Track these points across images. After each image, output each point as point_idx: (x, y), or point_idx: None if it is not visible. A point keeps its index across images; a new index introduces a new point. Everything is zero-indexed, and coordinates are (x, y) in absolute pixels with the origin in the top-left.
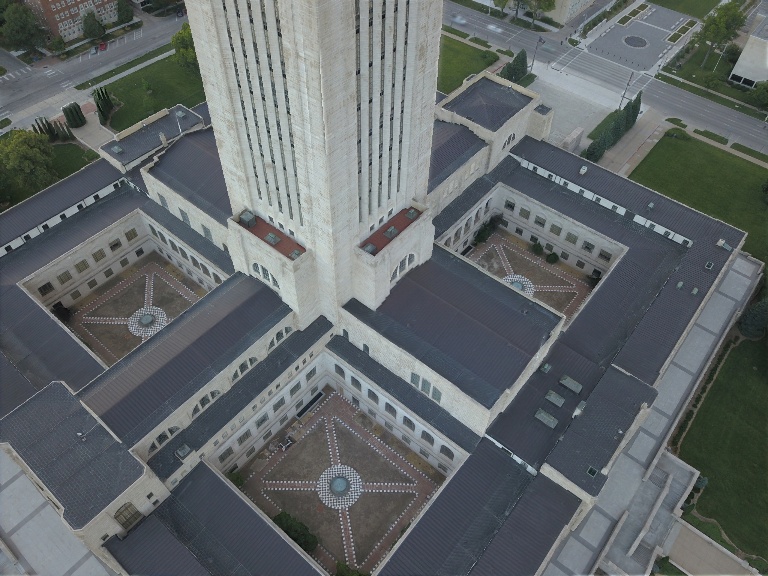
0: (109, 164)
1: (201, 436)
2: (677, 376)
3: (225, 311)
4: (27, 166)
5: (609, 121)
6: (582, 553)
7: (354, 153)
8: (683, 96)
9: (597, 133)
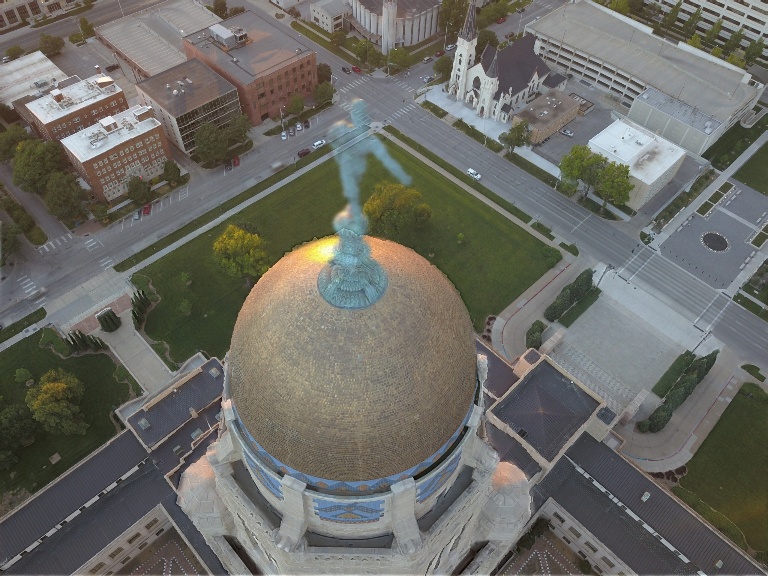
0: (135, 438)
1: None
2: None
3: None
4: (53, 421)
5: (678, 369)
6: None
7: None
8: (764, 331)
9: (663, 387)
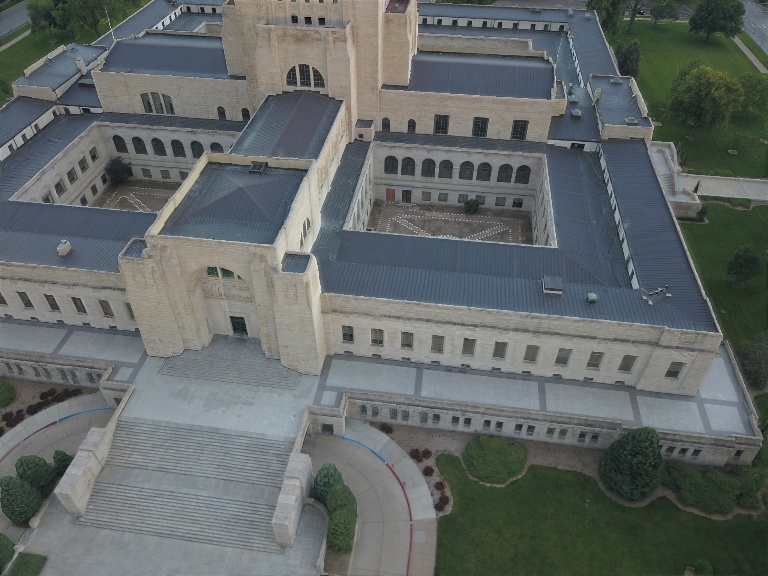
0: None
1: None
2: None
3: None
4: None
5: None
6: None
7: None
8: None
9: None
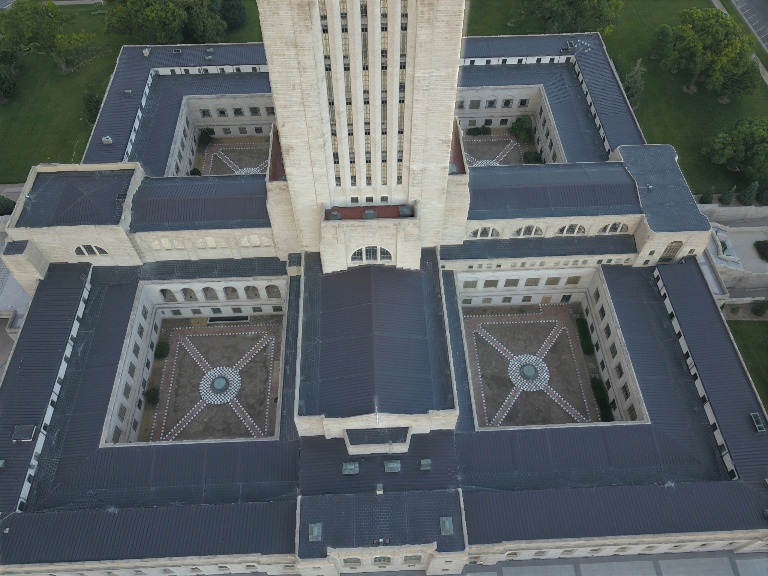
0: None
1: None
2: None
3: (505, 191)
4: None
5: None
6: None
7: None
8: None
9: None
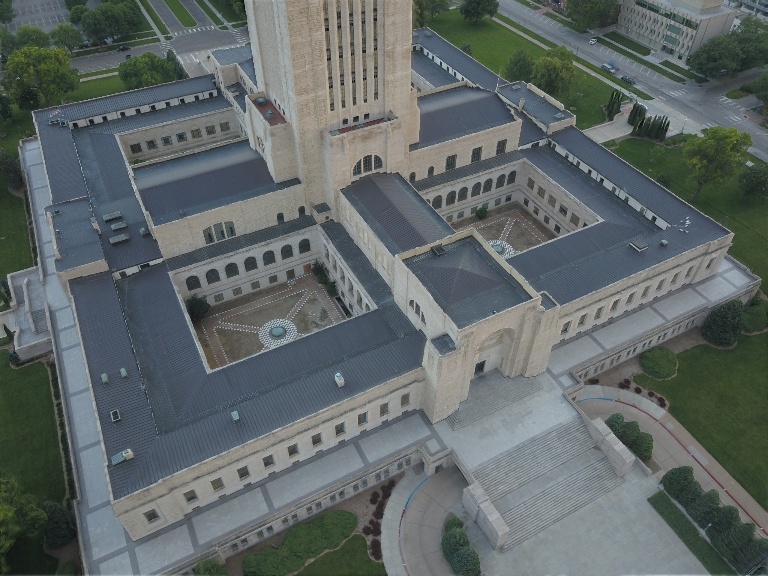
0: None
1: (241, 99)
2: (82, 381)
3: None
4: None
5: None
6: (51, 251)
7: (251, 4)
8: None
9: None
